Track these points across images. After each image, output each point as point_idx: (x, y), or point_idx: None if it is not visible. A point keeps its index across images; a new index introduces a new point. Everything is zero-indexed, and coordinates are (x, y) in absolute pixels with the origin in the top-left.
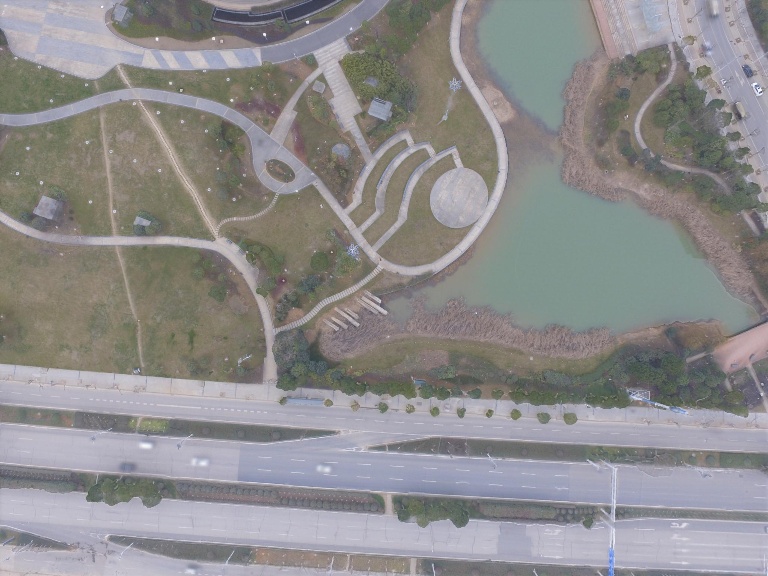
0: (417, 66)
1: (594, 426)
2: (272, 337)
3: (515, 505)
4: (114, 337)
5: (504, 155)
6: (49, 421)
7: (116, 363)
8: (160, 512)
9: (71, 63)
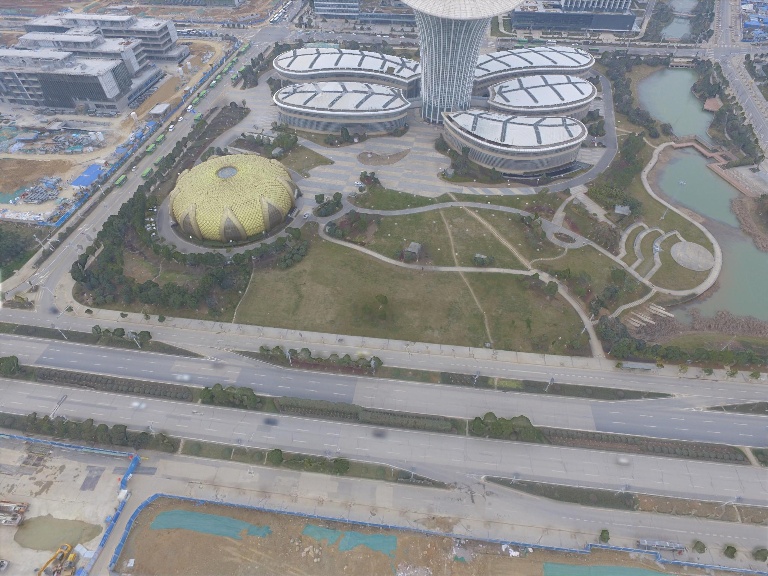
0: (633, 196)
1: None
2: (591, 326)
3: None
4: (467, 322)
5: (711, 236)
6: (419, 378)
7: (470, 340)
8: (531, 456)
9: (419, 191)
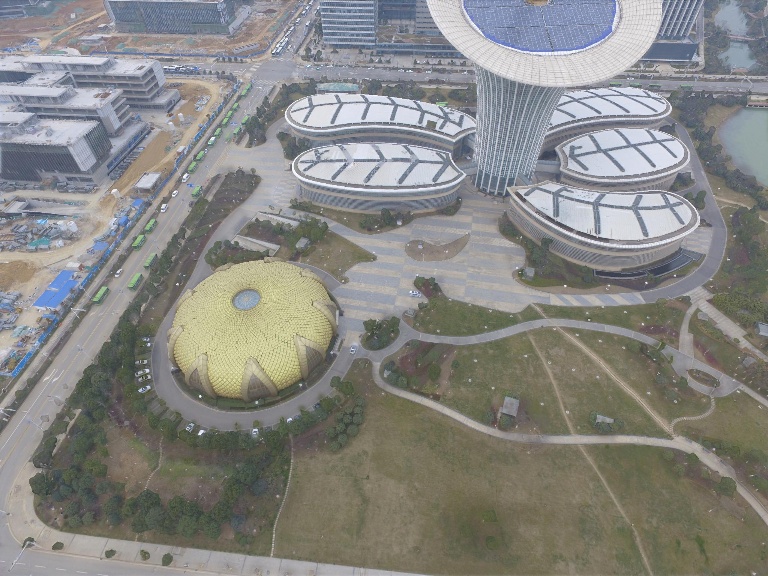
0: None
1: None
2: None
3: None
4: (612, 545)
5: None
6: None
7: None
8: None
9: (494, 303)
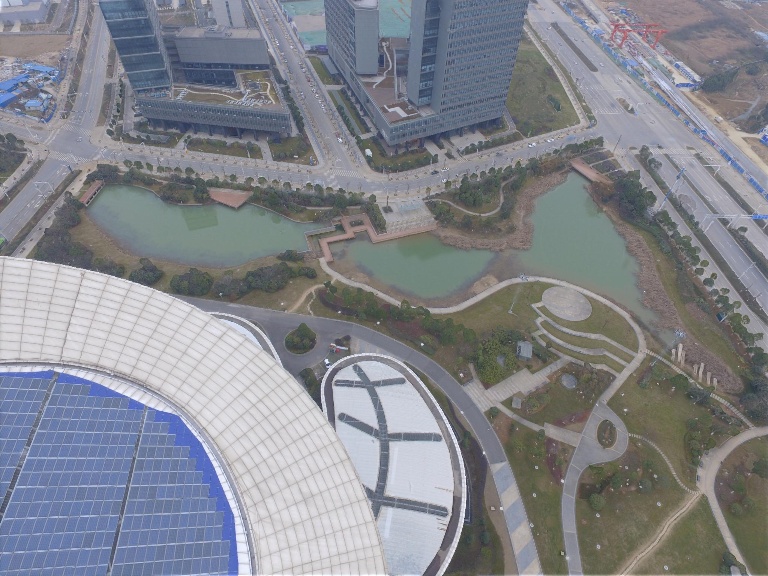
0: None
1: (680, 231)
2: (759, 429)
3: (761, 263)
4: None
5: None
6: None
7: None
8: None
9: None
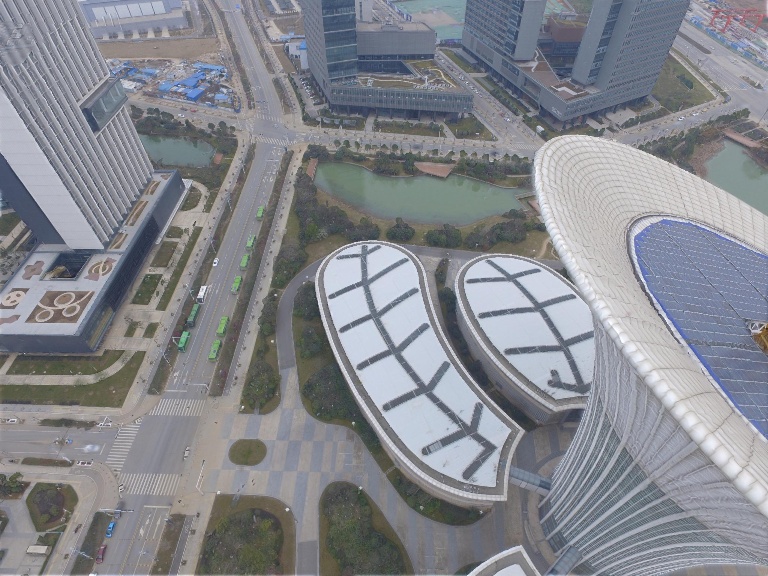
0: None
1: None
2: None
3: None
4: None
5: None
6: None
7: None
8: None
9: None
